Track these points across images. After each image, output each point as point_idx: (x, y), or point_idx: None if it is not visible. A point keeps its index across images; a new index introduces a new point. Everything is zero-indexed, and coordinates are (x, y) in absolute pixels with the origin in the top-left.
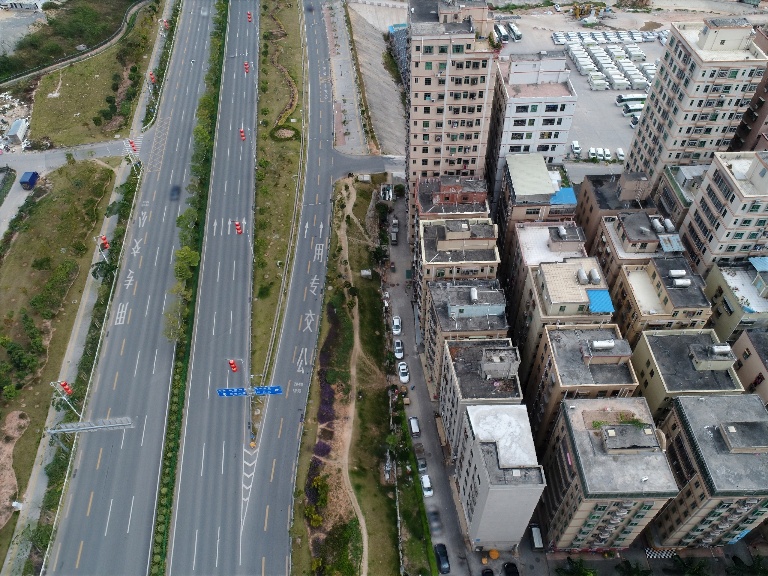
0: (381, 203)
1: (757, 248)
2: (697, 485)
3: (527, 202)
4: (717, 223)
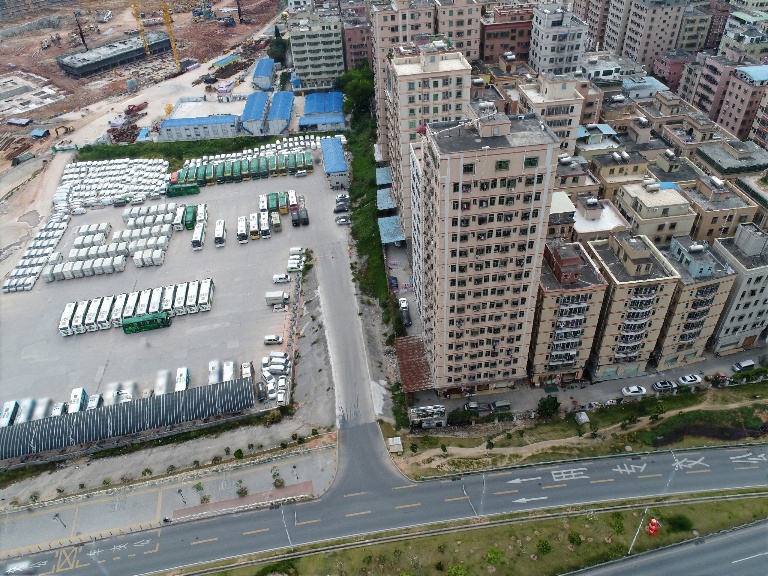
0: (455, 413)
1: None
2: None
3: None
4: (567, 133)
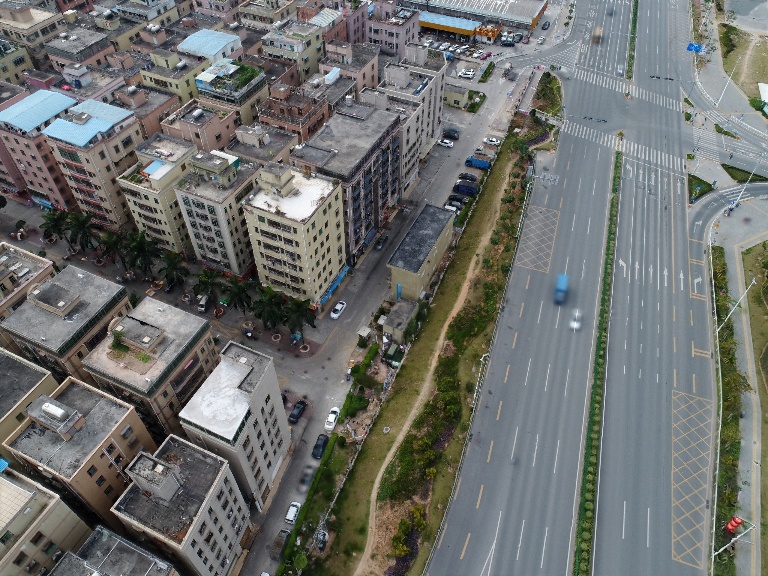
0: None
1: None
2: (121, 314)
3: None
4: None
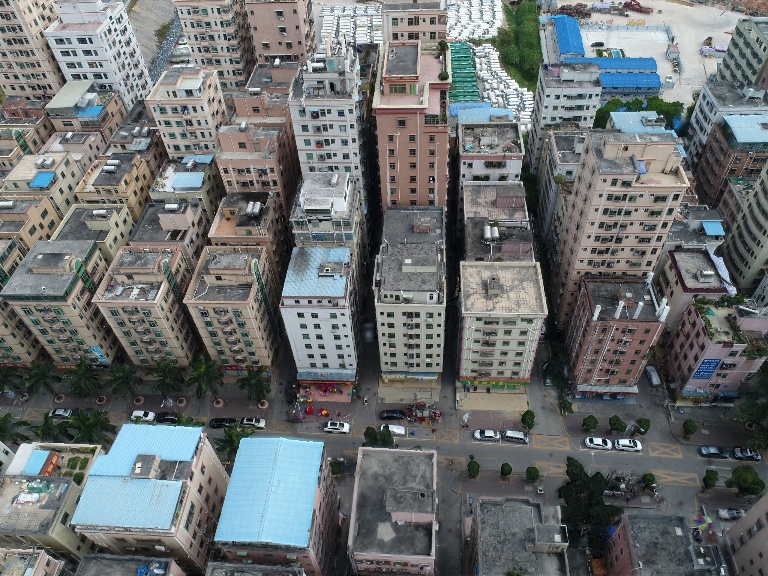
0: None
1: (196, 148)
2: None
3: (59, 115)
4: None
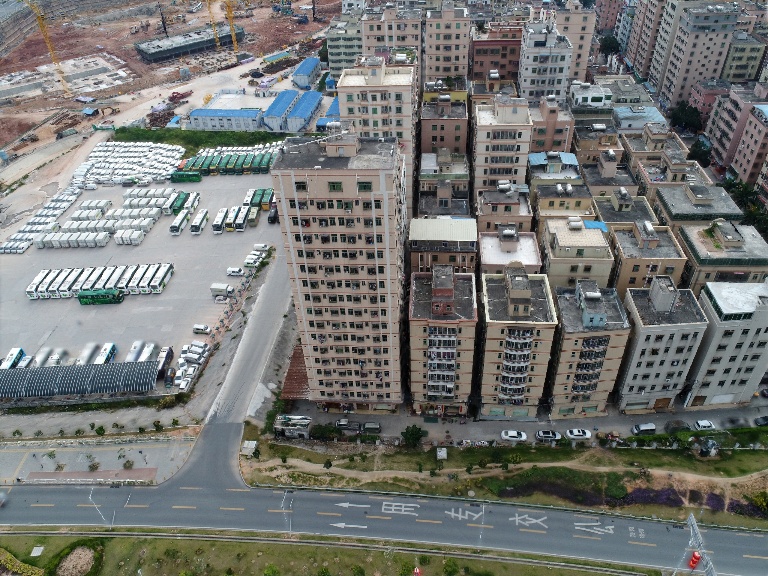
0: (317, 427)
1: None
2: None
3: None
4: (516, 159)
